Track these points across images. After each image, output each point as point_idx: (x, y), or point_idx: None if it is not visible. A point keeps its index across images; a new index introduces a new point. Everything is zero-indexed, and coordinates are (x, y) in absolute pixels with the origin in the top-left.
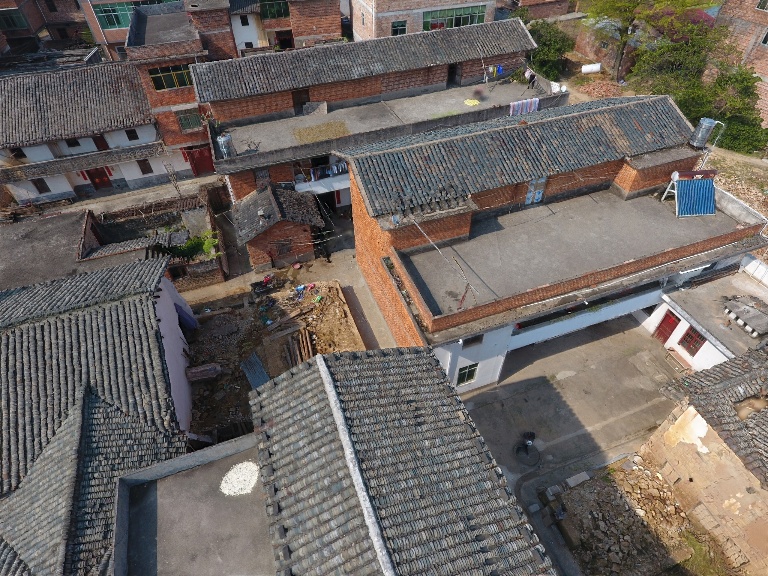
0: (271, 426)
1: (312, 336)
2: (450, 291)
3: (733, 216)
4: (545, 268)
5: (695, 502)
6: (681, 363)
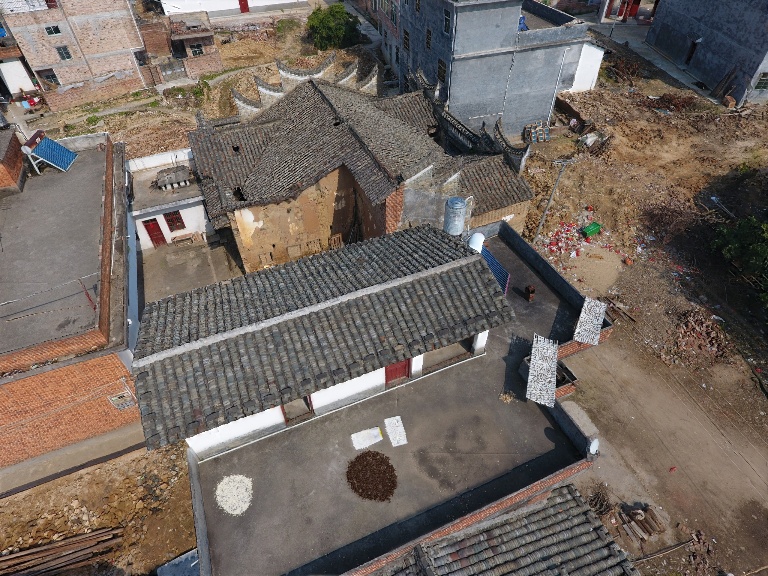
0: (201, 413)
1: (3, 556)
2: (58, 326)
3: (87, 148)
4: (72, 254)
5: (285, 252)
6: (187, 237)
